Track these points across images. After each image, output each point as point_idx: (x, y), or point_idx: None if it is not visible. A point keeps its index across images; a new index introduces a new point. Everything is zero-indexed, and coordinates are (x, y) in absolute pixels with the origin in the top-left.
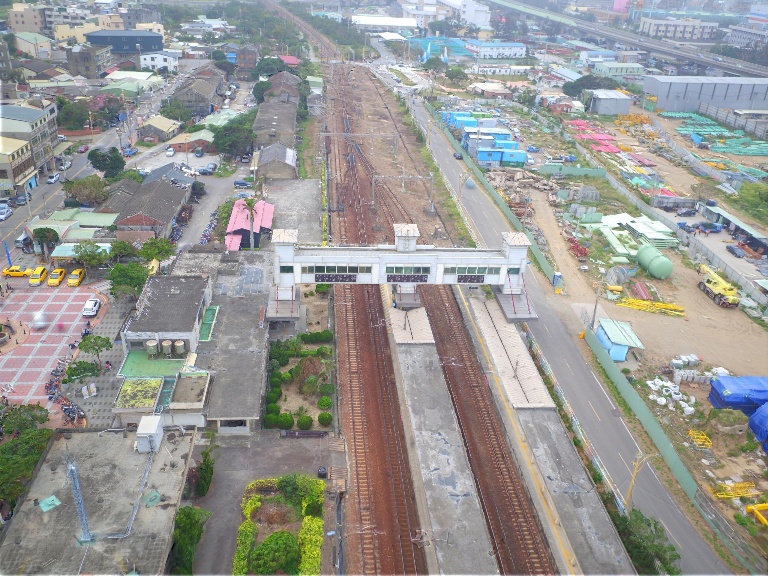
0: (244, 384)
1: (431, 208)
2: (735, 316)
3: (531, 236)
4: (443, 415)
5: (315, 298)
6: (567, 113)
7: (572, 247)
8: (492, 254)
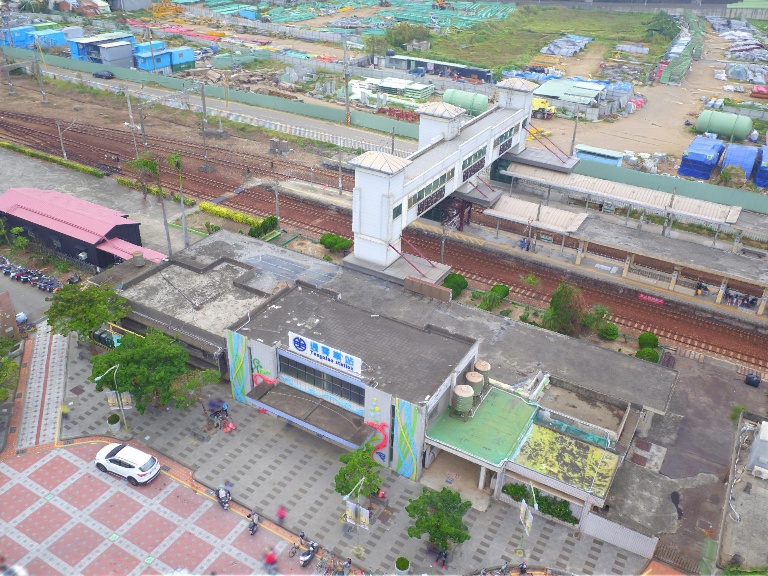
0: (587, 359)
1: (213, 129)
2: (564, 122)
3: (369, 115)
4: (732, 258)
5: (338, 260)
6: (100, 15)
7: (399, 115)
8: (503, 112)
